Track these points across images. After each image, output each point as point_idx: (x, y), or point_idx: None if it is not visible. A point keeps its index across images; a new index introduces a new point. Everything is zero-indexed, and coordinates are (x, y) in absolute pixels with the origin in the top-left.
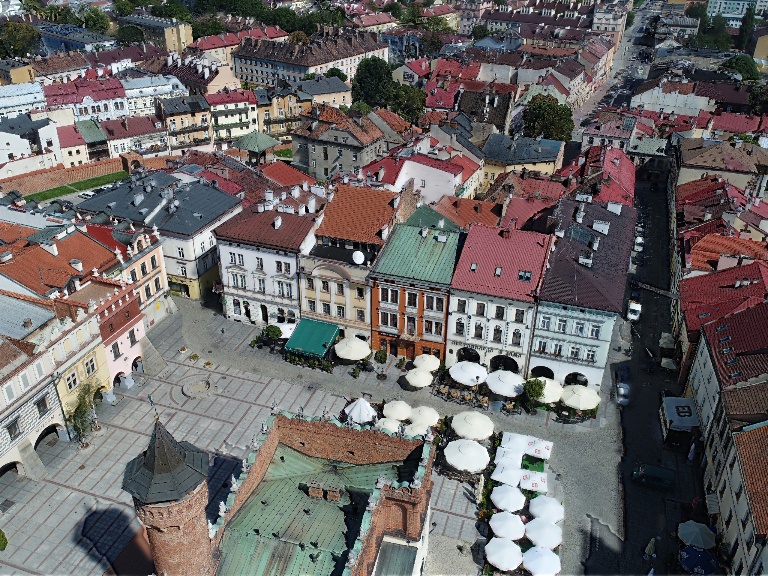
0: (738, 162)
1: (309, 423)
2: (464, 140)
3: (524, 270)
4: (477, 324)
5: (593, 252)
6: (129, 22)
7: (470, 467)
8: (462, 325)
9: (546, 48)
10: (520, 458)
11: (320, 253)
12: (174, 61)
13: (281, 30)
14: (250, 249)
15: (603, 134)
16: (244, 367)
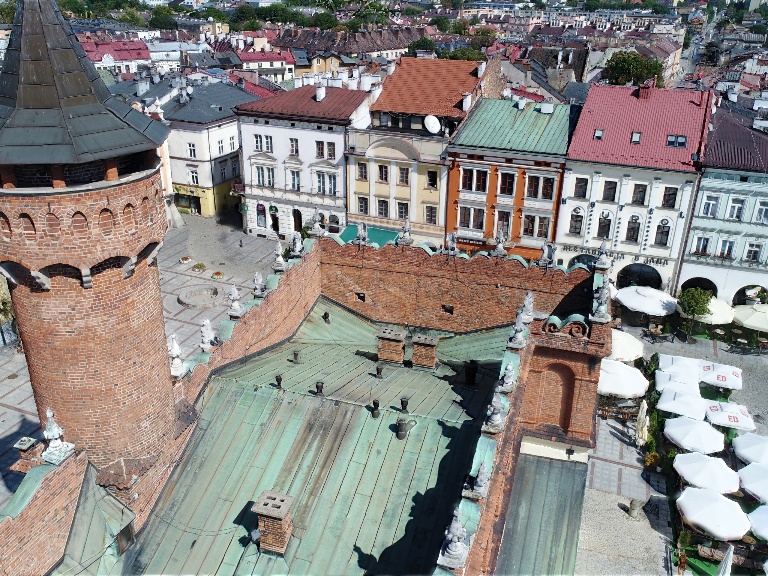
0: None
1: (375, 251)
2: (541, 78)
3: (675, 134)
4: (603, 215)
5: None
6: None
7: (621, 390)
8: (579, 220)
9: None
10: (696, 385)
11: None
12: (207, 39)
13: None
14: (282, 126)
15: None
16: None
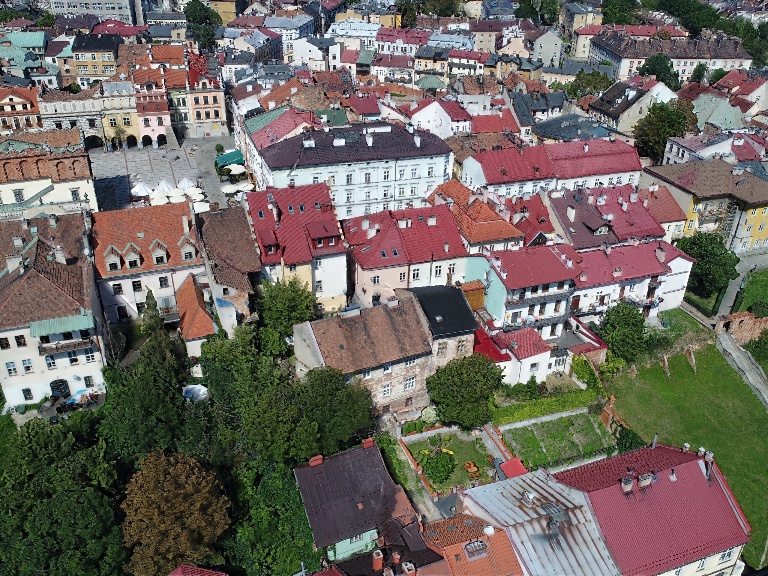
0: (691, 180)
1: None
2: None
3: None
4: None
5: (332, 146)
6: (566, 7)
7: None
8: None
9: None
10: None
11: (255, 111)
12: None
13: (680, 31)
14: None
15: (680, 143)
16: (199, 161)
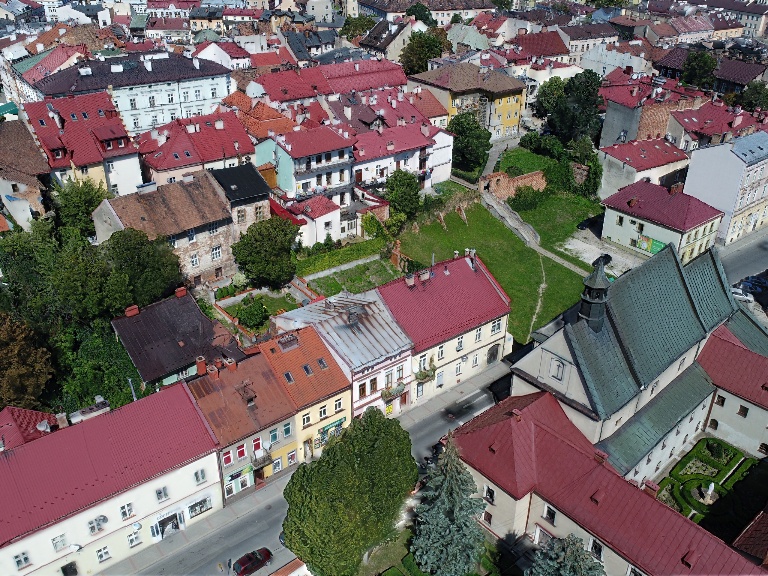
0: (447, 79)
1: None
2: None
3: (50, 70)
4: None
5: (110, 73)
6: None
7: None
8: None
9: (636, 19)
10: None
11: None
12: None
13: None
14: None
15: (439, 62)
16: None
